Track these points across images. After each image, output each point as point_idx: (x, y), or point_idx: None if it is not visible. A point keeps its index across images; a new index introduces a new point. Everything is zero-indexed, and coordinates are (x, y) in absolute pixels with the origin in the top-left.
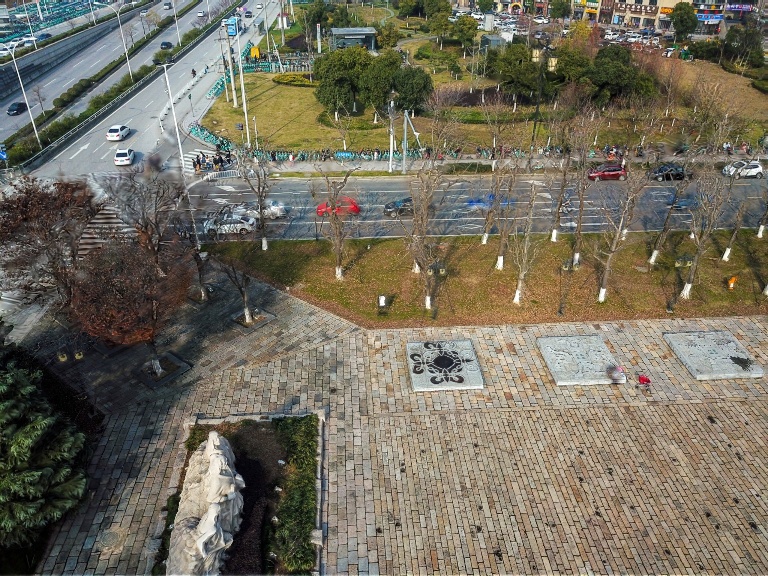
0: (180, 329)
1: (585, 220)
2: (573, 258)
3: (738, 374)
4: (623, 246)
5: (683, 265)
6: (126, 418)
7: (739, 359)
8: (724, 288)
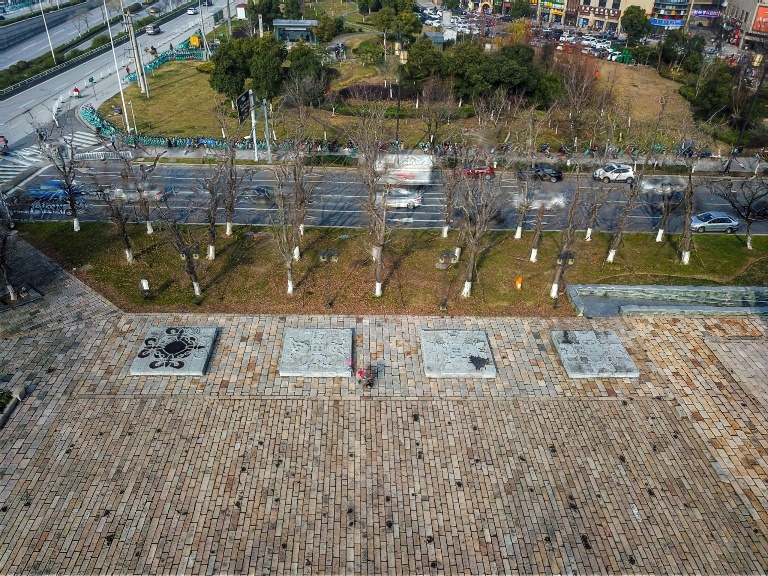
0: None
1: (424, 216)
2: None
3: (469, 373)
4: (382, 239)
5: (448, 261)
6: None
7: (478, 359)
8: (513, 288)
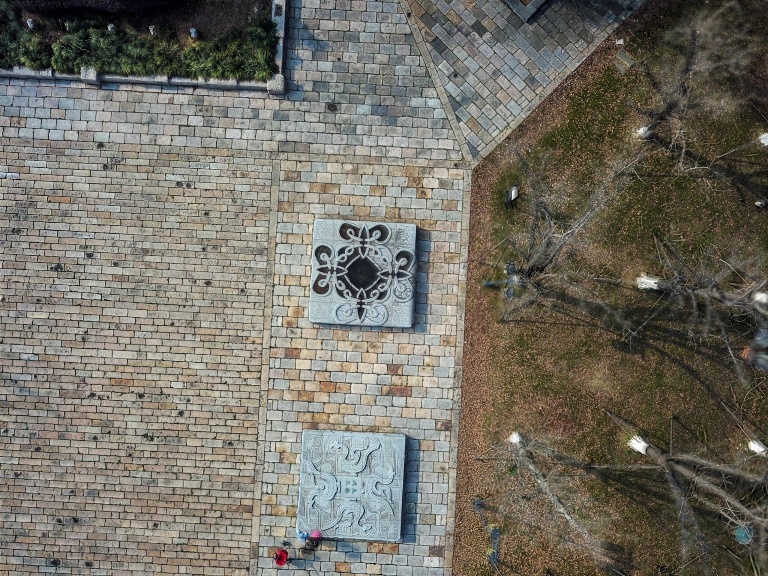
0: None
1: None
2: None
3: None
4: None
5: None
6: None
7: None
8: None
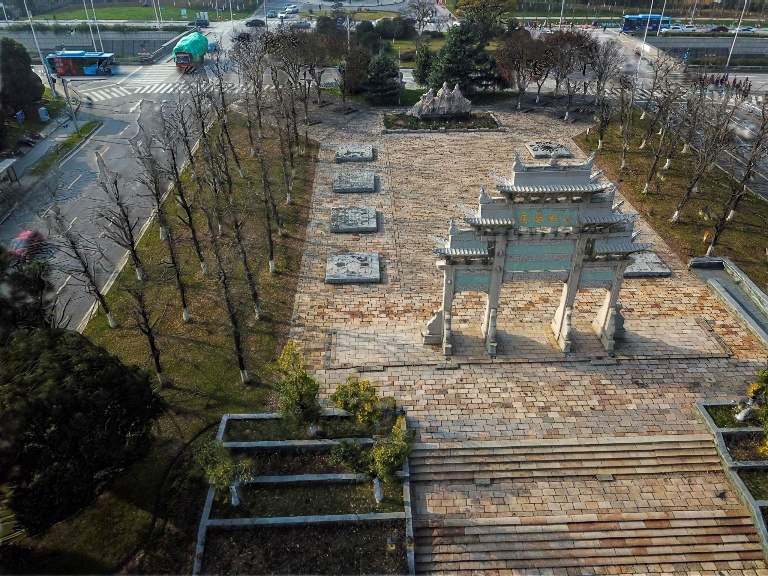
0: (552, 110)
1: None
2: None
3: None
4: None
5: None
6: (491, 107)
7: None
8: None
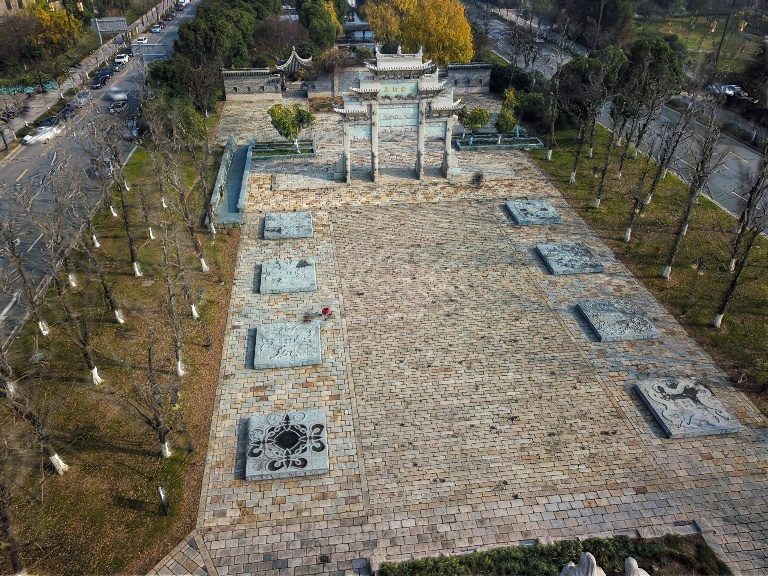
0: None
1: None
2: (115, 318)
3: None
4: None
5: None
6: None
7: (299, 264)
8: None
